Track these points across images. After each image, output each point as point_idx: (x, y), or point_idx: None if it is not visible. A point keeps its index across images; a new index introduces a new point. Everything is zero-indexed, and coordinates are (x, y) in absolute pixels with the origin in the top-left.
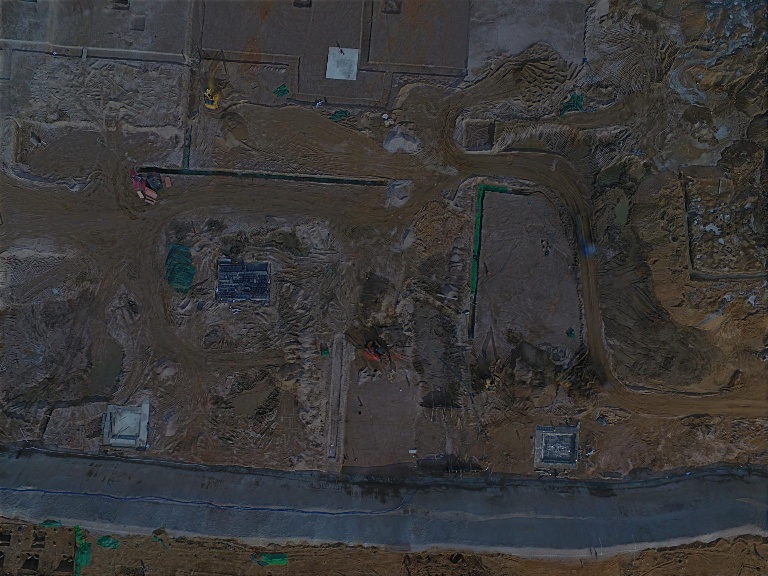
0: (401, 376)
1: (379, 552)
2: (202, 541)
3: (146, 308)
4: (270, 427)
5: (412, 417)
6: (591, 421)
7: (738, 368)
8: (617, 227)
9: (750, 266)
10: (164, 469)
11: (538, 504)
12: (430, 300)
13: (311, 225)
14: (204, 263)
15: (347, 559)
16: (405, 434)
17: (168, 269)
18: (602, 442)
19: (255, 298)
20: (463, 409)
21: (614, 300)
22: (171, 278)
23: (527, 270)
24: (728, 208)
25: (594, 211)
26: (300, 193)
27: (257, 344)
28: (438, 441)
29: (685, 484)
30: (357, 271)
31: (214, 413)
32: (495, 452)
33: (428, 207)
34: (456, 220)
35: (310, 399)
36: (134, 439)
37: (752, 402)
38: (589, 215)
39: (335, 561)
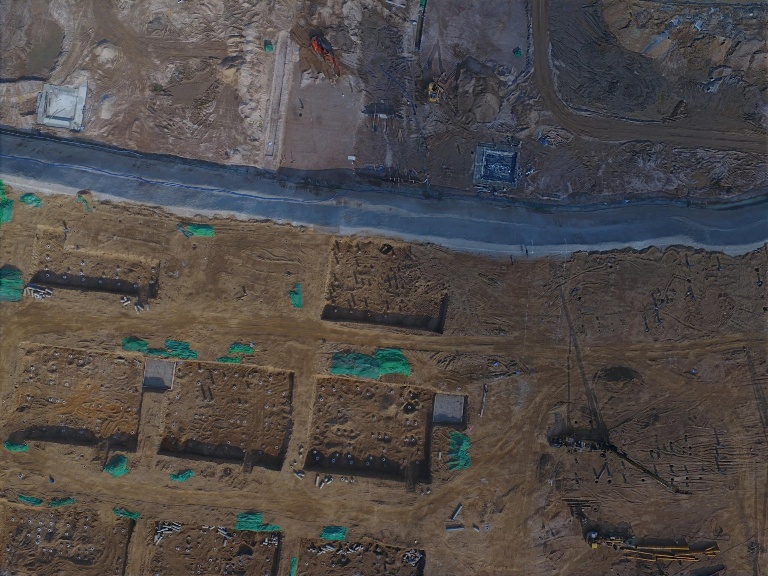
0: (344, 82)
1: (307, 232)
2: (128, 206)
3: None
4: (208, 119)
5: (353, 123)
6: (533, 142)
7: (682, 99)
8: None
9: None
10: (97, 151)
11: (473, 211)
12: (378, 9)
13: None
14: None
15: (274, 236)
16: (345, 140)
17: None
18: (543, 163)
19: None
20: (405, 119)
21: (563, 23)
22: None
23: None
24: None
25: None
26: None
27: (200, 35)
28: (378, 152)
29: (623, 208)
30: None
31: (152, 100)
32: (435, 165)
33: None
34: None
35: (250, 91)
36: (69, 121)
37: (694, 132)
38: None
39: (262, 237)
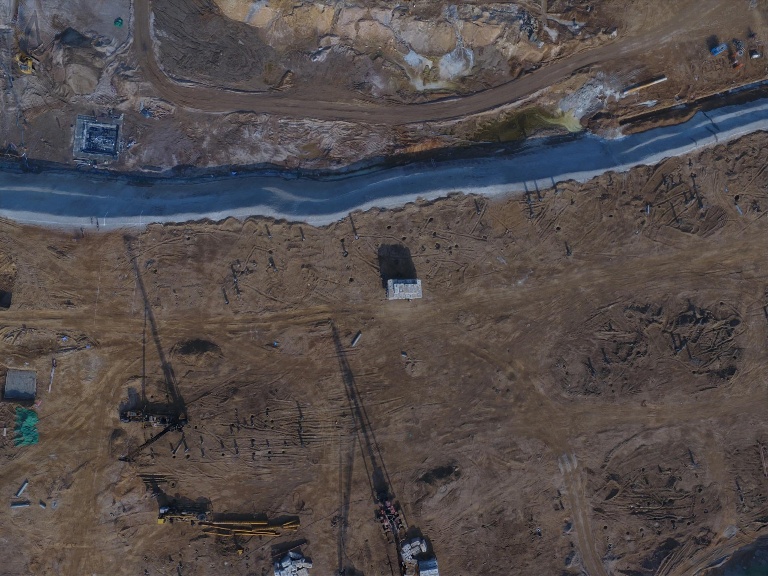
0: None
1: None
2: None
3: None
4: None
5: None
6: (136, 114)
7: (289, 68)
8: None
9: None
10: None
11: (61, 184)
12: None
13: None
14: None
15: None
16: None
17: None
18: (145, 135)
19: None
20: (2, 92)
21: None
22: None
23: None
24: None
25: None
26: None
27: None
28: None
29: (225, 180)
30: None
31: None
32: (33, 138)
33: None
34: None
35: None
36: None
37: (300, 102)
38: None
39: None
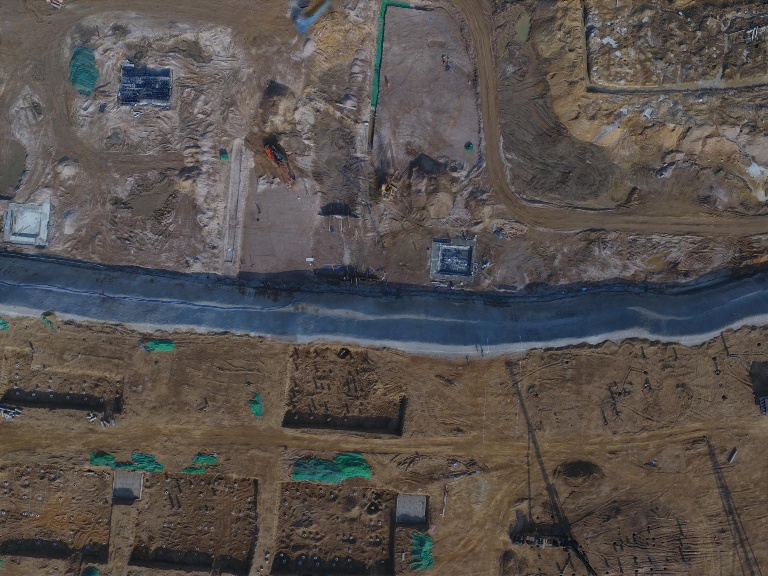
0: (300, 185)
1: (265, 342)
2: (90, 325)
3: (49, 109)
4: (168, 229)
5: (310, 225)
6: (488, 235)
7: (636, 185)
8: (517, 43)
9: (647, 80)
10: (62, 266)
11: (430, 309)
12: (330, 111)
13: (214, 33)
14: (107, 66)
15: (233, 348)
16: (302, 242)
17: (72, 71)
18: (498, 255)
19: (157, 102)
20: (360, 219)
21: (513, 115)
22: (74, 79)
23: (427, 84)
24: (625, 21)
25: (495, 27)
26: (203, 0)
27: (157, 147)
28: (336, 251)
29: (580, 298)
30: (258, 78)
31: (113, 213)
32: (391, 262)
33: (329, 17)
34: (357, 32)
35: (207, 201)
36: (34, 237)
37: (649, 218)
38: (489, 30)
39: (221, 349)
